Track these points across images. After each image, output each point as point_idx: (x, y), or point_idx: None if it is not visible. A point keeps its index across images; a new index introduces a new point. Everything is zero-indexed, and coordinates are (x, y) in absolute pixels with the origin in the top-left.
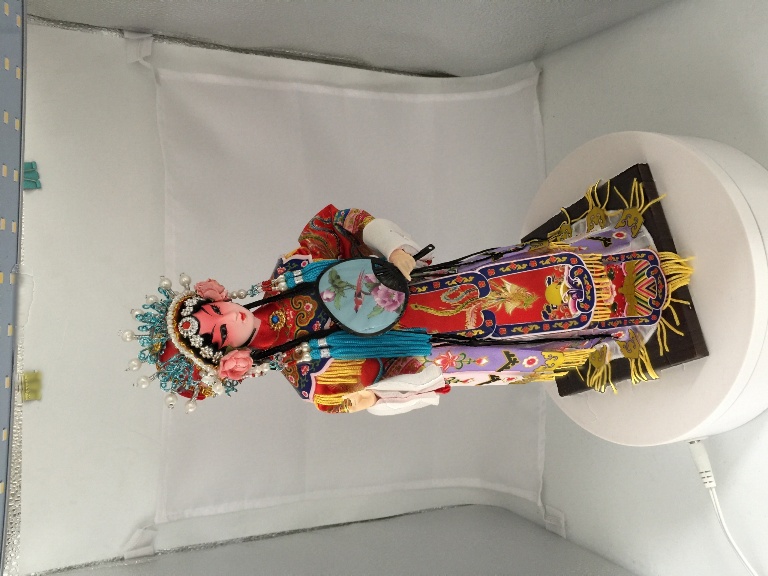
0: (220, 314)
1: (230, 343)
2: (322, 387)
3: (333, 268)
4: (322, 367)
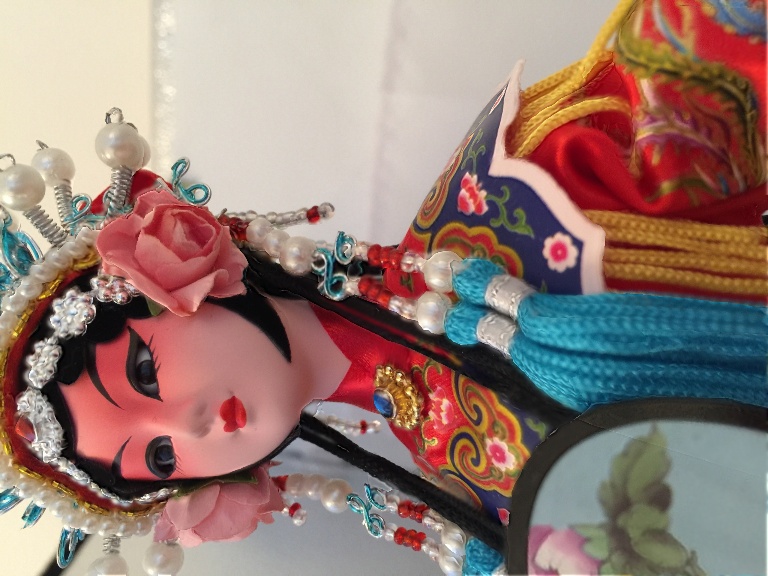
0: (154, 396)
1: (193, 475)
2: None
3: (660, 430)
4: None
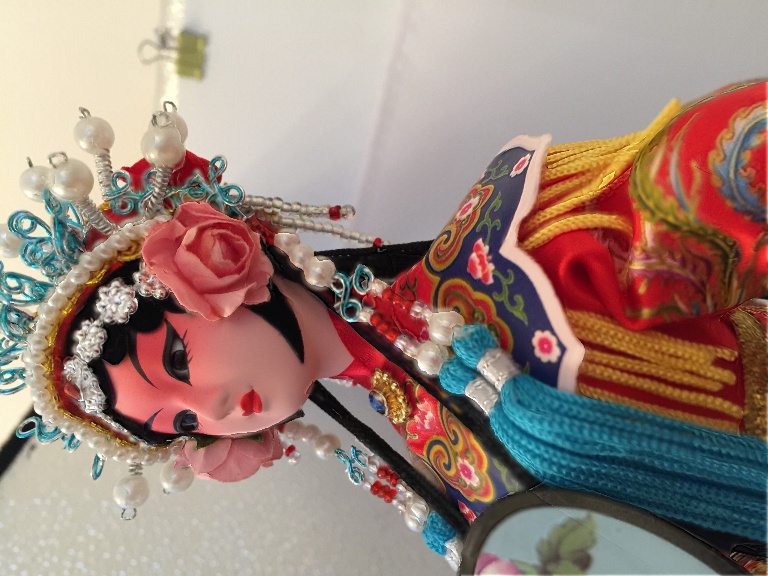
0: (185, 381)
1: None
2: None
3: (592, 518)
4: None
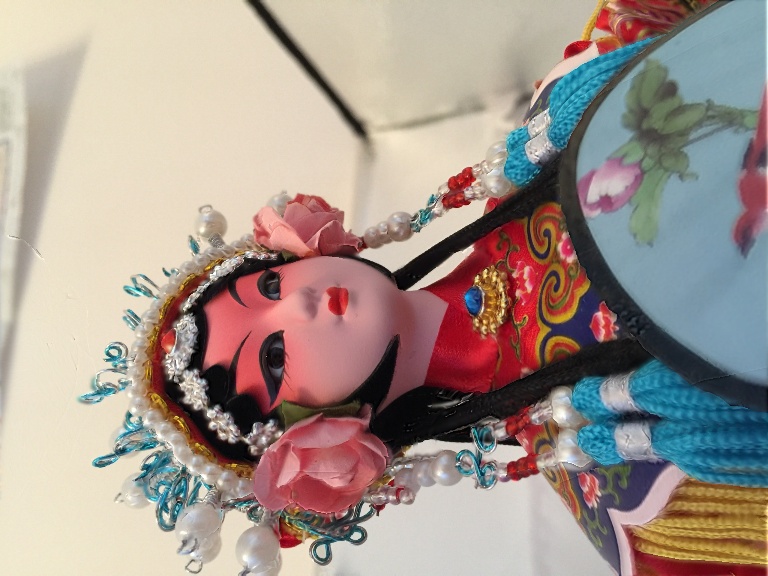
0: (276, 298)
1: (299, 392)
2: (673, 561)
3: (650, 58)
4: (639, 497)
